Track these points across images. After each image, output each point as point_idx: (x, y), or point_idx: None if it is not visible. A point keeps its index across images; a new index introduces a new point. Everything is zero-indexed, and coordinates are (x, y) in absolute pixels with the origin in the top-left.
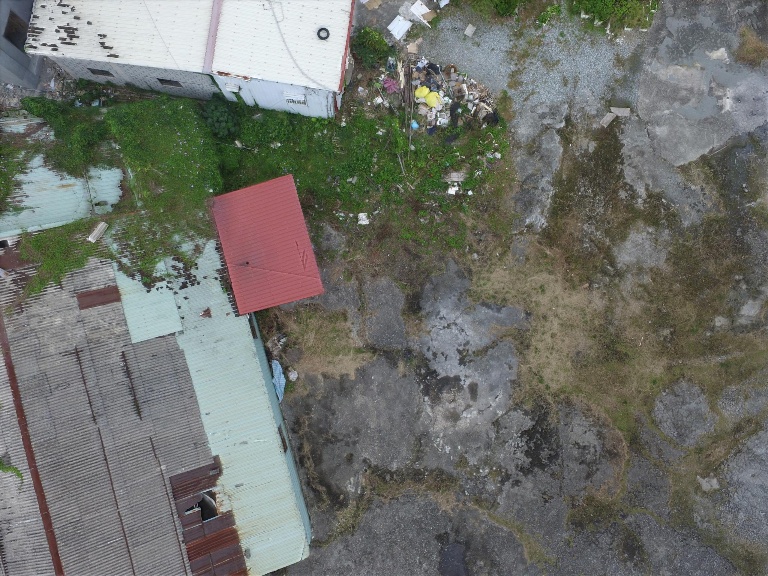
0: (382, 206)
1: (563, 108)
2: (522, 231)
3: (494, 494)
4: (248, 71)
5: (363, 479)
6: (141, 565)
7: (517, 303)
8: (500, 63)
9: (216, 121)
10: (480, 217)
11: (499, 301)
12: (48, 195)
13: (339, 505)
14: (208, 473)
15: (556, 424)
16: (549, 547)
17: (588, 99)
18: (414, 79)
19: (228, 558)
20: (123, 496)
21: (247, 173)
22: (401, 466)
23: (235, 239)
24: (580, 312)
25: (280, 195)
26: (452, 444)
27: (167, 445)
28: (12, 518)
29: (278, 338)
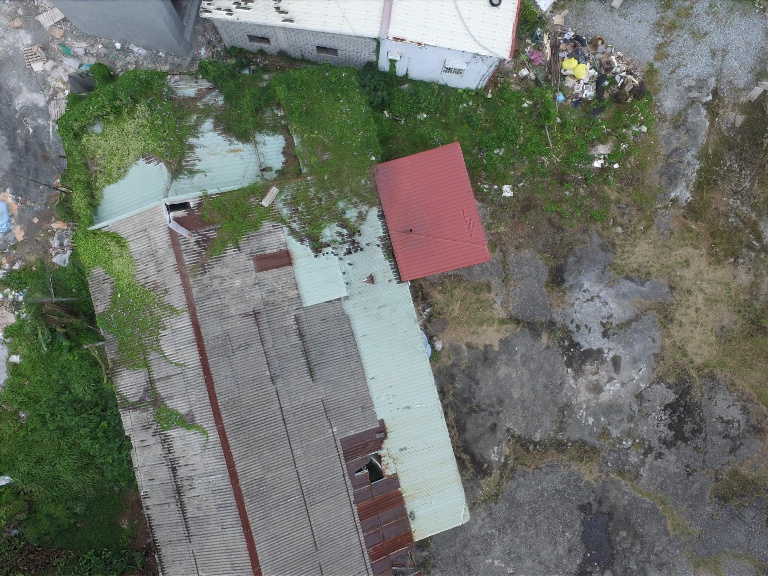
0: (527, 178)
1: (710, 82)
2: (667, 205)
3: (637, 466)
4: (422, 37)
5: (507, 448)
6: (318, 523)
7: (661, 277)
8: (647, 36)
9: (373, 90)
10: (625, 190)
11: (643, 275)
12: (218, 160)
13: (483, 474)
14: (374, 436)
15: (700, 398)
16: (692, 519)
17: (735, 73)
18: (561, 51)
19: (394, 520)
20: (300, 456)
21: (397, 143)
22: (544, 436)
23: (398, 206)
24: (725, 287)
25: (446, 163)
26: (595, 416)
27: (337, 408)
28: (195, 474)
29: (423, 308)
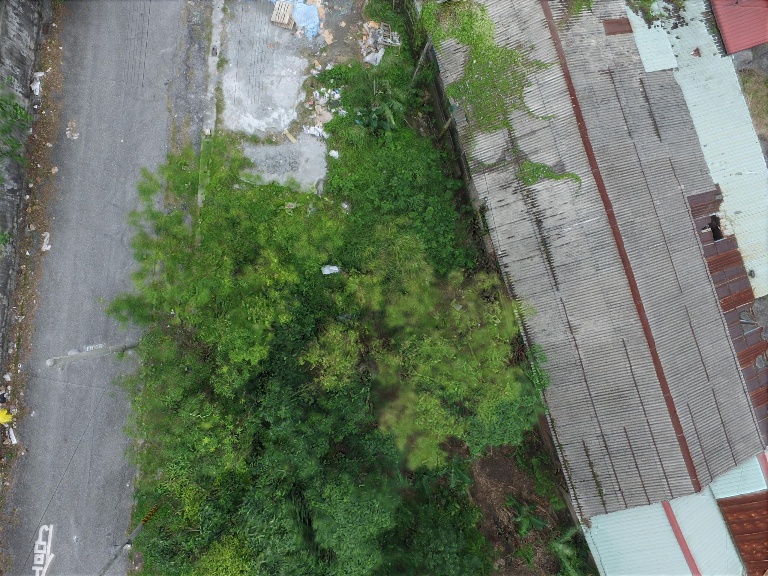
0: None
1: None
2: None
3: None
4: None
5: None
6: (679, 270)
7: None
8: None
9: None
10: None
11: None
12: None
13: None
14: (713, 199)
15: None
16: None
17: None
18: None
19: (736, 277)
20: (659, 206)
21: None
22: None
23: None
24: None
25: None
26: None
27: (681, 168)
28: (565, 222)
29: None
